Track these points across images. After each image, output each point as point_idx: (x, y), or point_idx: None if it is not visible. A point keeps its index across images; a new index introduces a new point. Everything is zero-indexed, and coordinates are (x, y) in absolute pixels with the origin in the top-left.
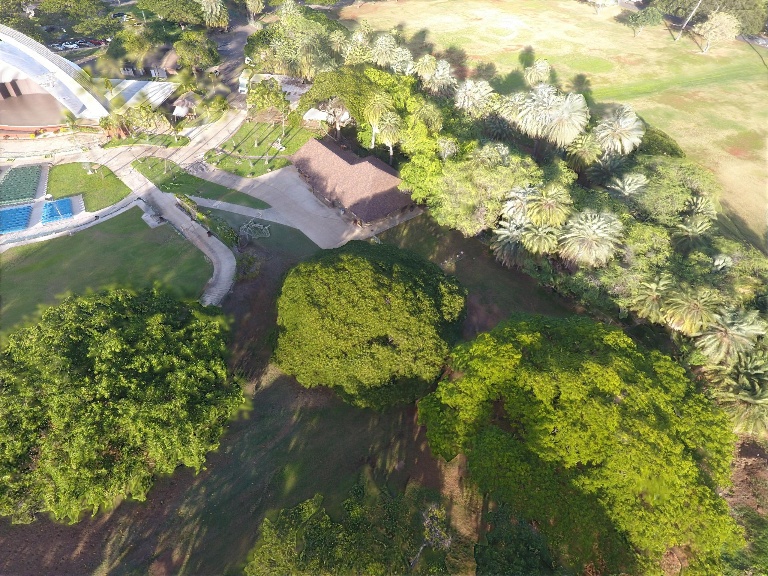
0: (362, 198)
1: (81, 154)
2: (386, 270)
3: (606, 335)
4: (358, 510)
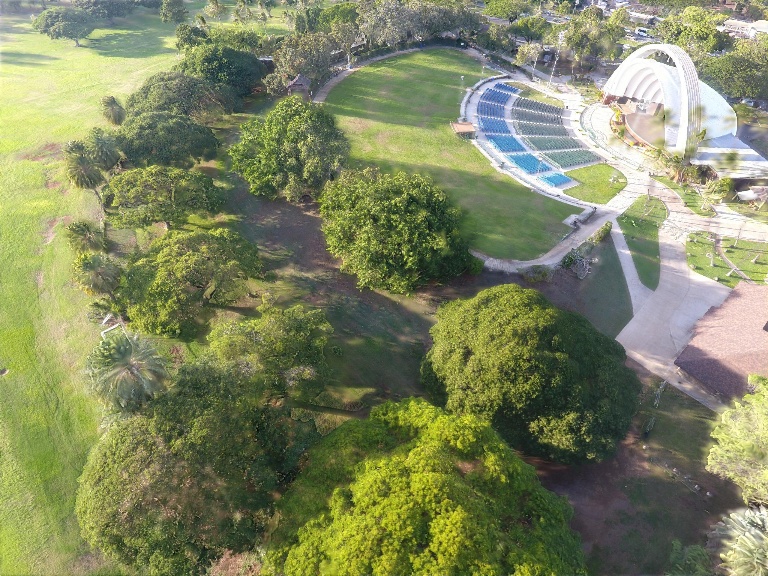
0: (711, 351)
1: (632, 170)
2: (552, 345)
3: (528, 569)
4: (319, 343)
